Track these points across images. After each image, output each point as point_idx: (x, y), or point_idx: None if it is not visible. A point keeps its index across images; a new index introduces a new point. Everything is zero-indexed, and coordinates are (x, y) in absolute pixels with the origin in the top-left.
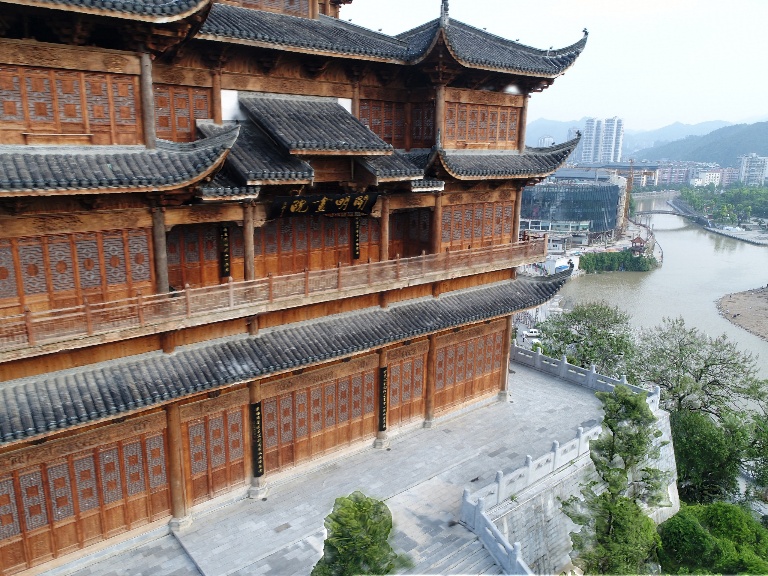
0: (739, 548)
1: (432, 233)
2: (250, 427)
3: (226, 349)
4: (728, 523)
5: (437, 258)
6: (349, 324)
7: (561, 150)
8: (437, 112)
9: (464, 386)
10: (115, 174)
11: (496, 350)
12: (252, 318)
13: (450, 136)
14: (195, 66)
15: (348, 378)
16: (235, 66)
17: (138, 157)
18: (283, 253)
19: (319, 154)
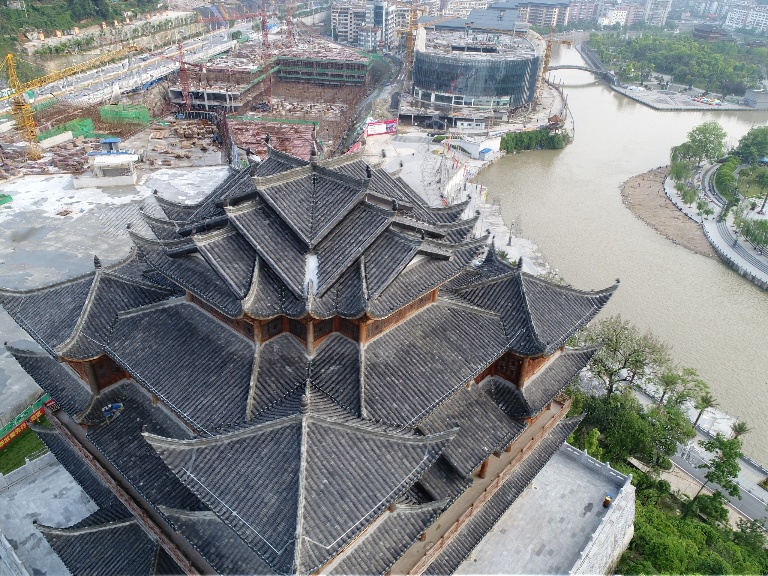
0: (672, 575)
1: None
2: None
3: None
4: (666, 557)
5: None
6: None
7: (590, 350)
8: (522, 369)
9: None
10: (389, 551)
11: None
12: None
13: (526, 375)
14: None
15: None
16: None
17: (389, 523)
18: None
19: None
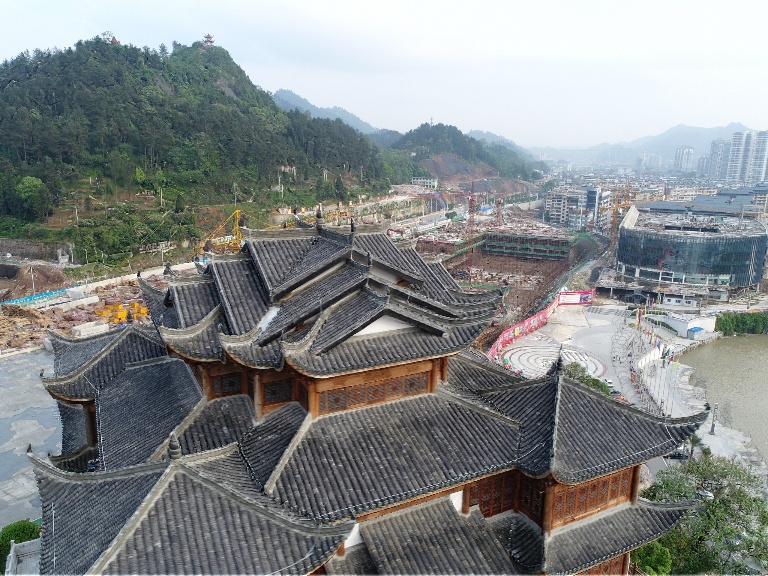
0: None
1: None
2: None
3: None
4: None
5: None
6: None
7: (677, 508)
8: (546, 504)
9: None
10: None
11: None
12: None
13: (558, 517)
14: None
15: None
16: None
17: None
18: None
19: None
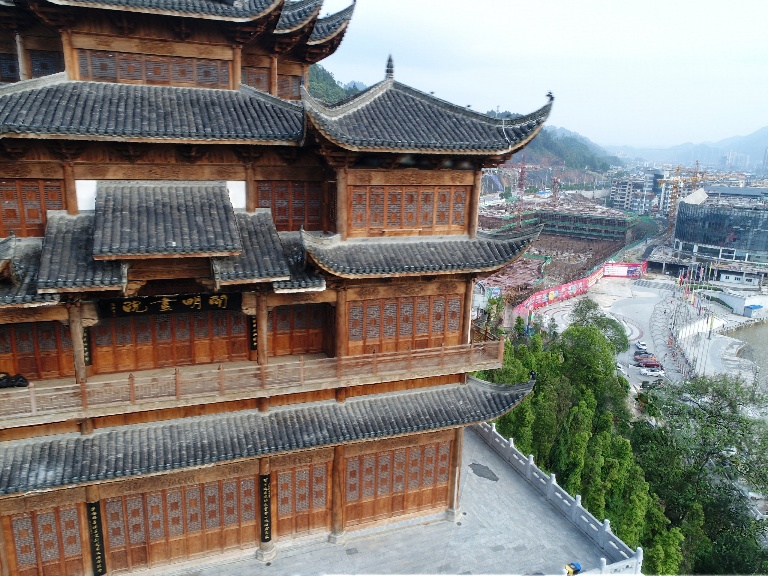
0: None
1: (335, 331)
2: (88, 525)
3: (44, 450)
4: None
5: (323, 364)
6: (207, 429)
7: (519, 238)
8: (337, 197)
9: (391, 499)
10: None
11: (440, 462)
12: (83, 418)
13: (359, 223)
14: (44, 158)
15: (218, 483)
16: (93, 155)
17: None
18: (159, 342)
19: (134, 258)
